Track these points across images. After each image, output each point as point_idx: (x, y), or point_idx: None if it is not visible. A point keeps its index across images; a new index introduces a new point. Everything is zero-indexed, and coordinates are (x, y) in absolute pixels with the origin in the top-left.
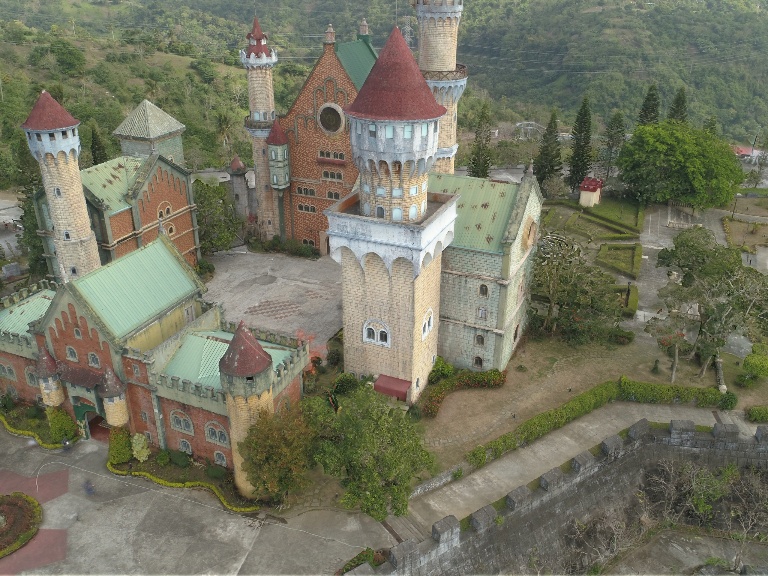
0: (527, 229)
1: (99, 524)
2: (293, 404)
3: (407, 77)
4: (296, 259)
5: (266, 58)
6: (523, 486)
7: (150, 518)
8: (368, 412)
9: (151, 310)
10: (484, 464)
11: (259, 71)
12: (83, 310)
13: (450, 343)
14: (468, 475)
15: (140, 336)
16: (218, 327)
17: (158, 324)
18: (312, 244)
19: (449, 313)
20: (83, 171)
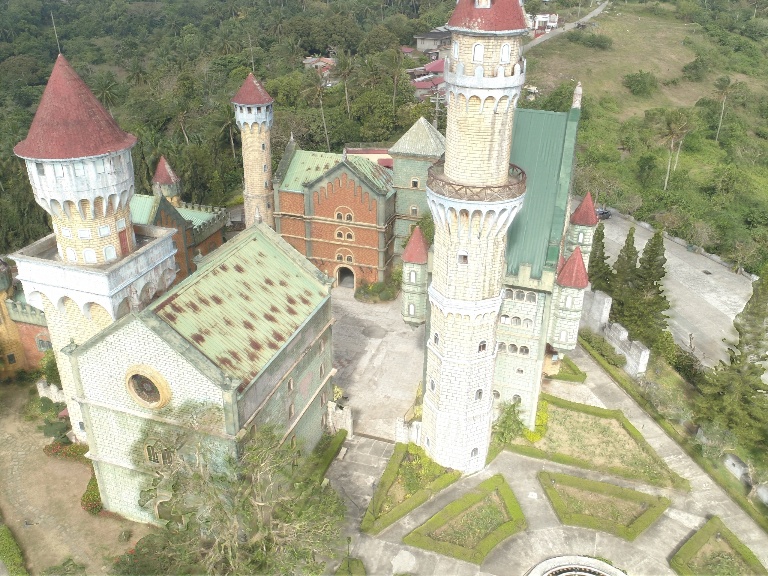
0: None
1: None
2: None
3: None
4: None
5: None
6: None
7: None
8: None
9: None
10: None
11: None
12: None
13: None
14: None
15: None
16: None
17: None
18: None
19: None
20: (311, 152)
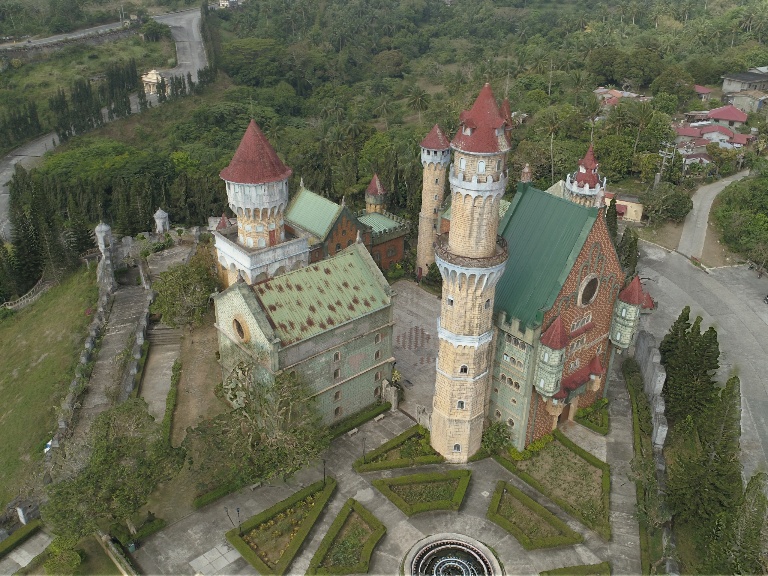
0: None
1: None
2: None
3: None
4: None
5: (569, 183)
6: (135, 366)
7: None
8: None
9: None
10: None
11: None
12: None
13: None
14: None
15: None
16: None
17: None
18: None
19: None
20: None
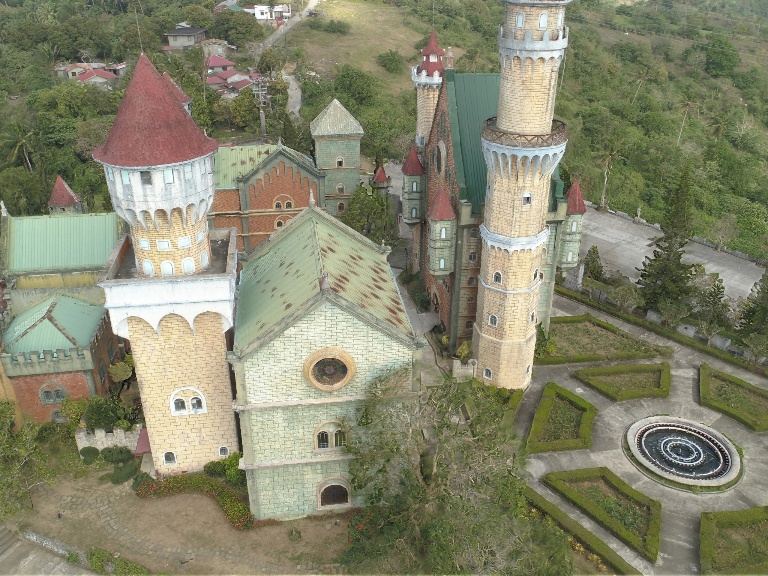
0: (310, 361)
1: None
2: (75, 397)
3: (126, 113)
4: (409, 303)
5: (425, 77)
6: None
7: None
8: None
9: (58, 264)
10: (104, 573)
11: (422, 90)
12: (1, 239)
13: None
14: (85, 568)
15: (38, 279)
16: None
17: (61, 277)
18: (428, 295)
19: None
20: None
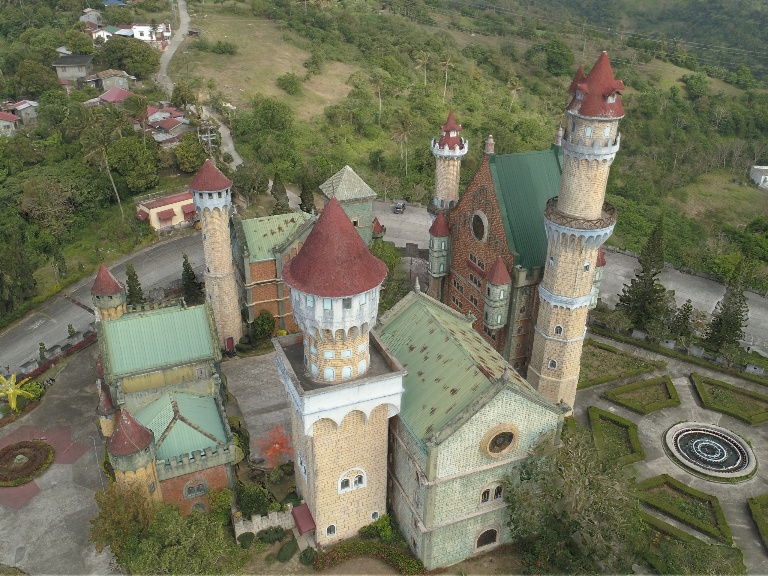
0: (488, 437)
1: (56, 498)
2: (215, 487)
3: (324, 248)
4: None
5: (448, 151)
6: None
7: (79, 514)
8: (168, 534)
9: (159, 361)
10: None
11: (443, 161)
12: None
13: (401, 508)
14: None
15: (140, 378)
16: (212, 394)
17: (162, 373)
18: None
19: (401, 480)
20: (256, 219)
